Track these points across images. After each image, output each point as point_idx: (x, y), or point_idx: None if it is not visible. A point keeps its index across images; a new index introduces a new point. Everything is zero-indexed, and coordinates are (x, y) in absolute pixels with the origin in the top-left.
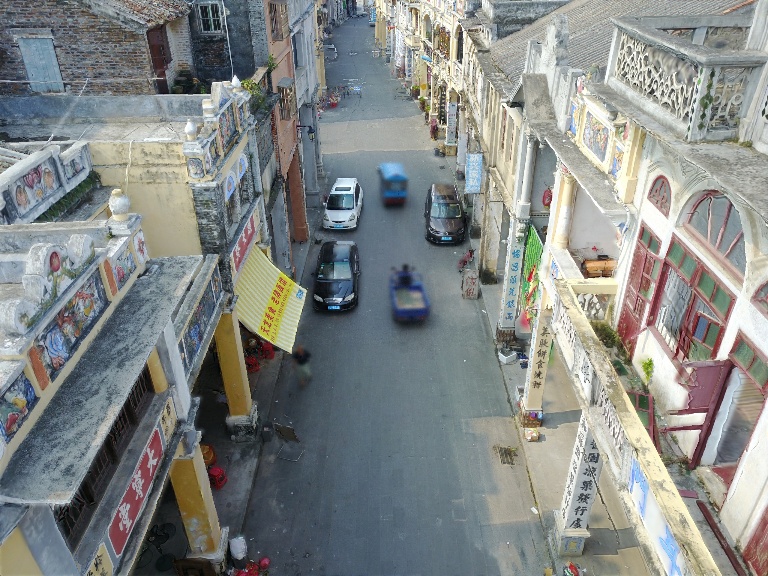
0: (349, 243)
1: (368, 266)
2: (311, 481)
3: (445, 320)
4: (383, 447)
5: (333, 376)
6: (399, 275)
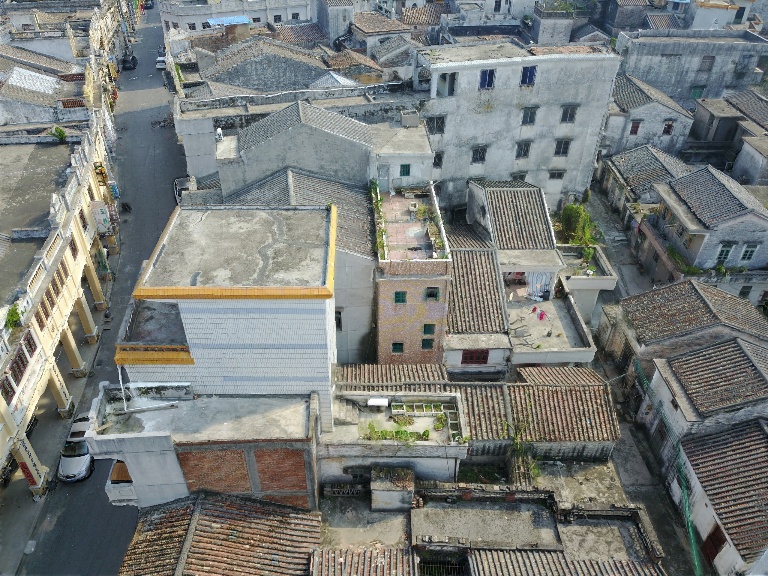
0: None
1: None
2: None
3: (140, 51)
4: (156, 40)
5: None
6: (148, 56)
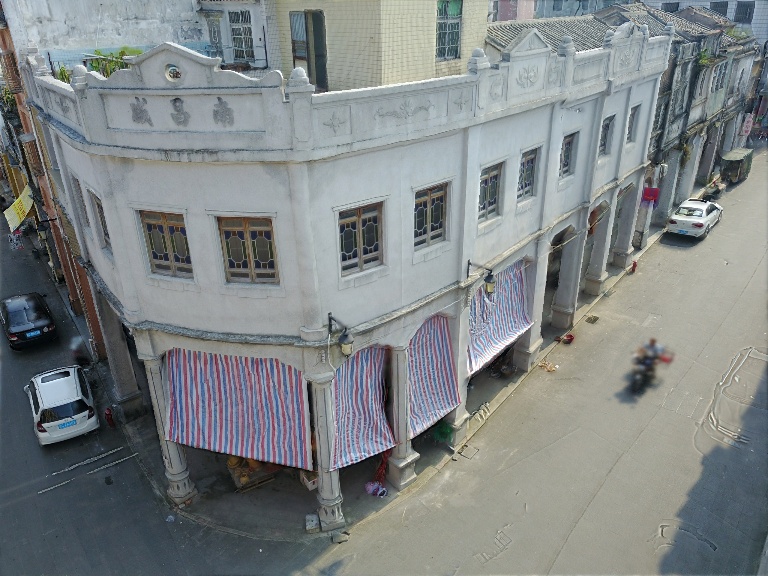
0: (17, 327)
1: (1, 356)
2: (3, 254)
3: None
4: None
5: (7, 282)
6: None
